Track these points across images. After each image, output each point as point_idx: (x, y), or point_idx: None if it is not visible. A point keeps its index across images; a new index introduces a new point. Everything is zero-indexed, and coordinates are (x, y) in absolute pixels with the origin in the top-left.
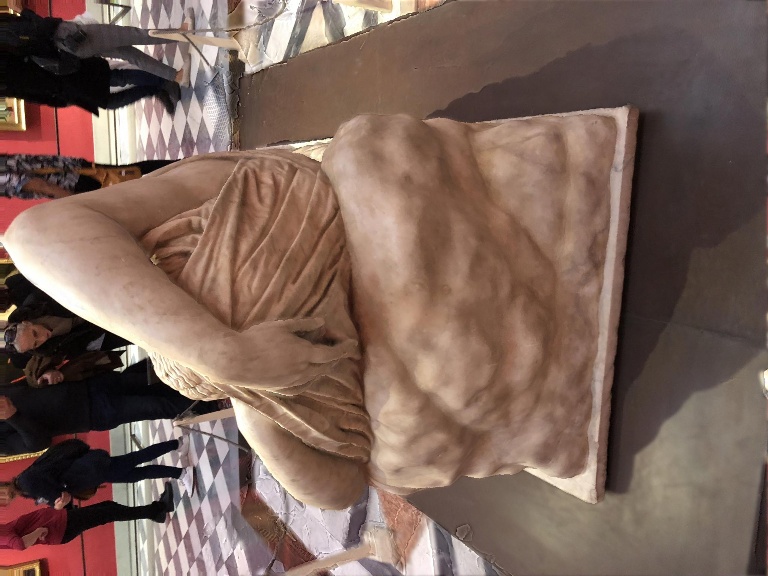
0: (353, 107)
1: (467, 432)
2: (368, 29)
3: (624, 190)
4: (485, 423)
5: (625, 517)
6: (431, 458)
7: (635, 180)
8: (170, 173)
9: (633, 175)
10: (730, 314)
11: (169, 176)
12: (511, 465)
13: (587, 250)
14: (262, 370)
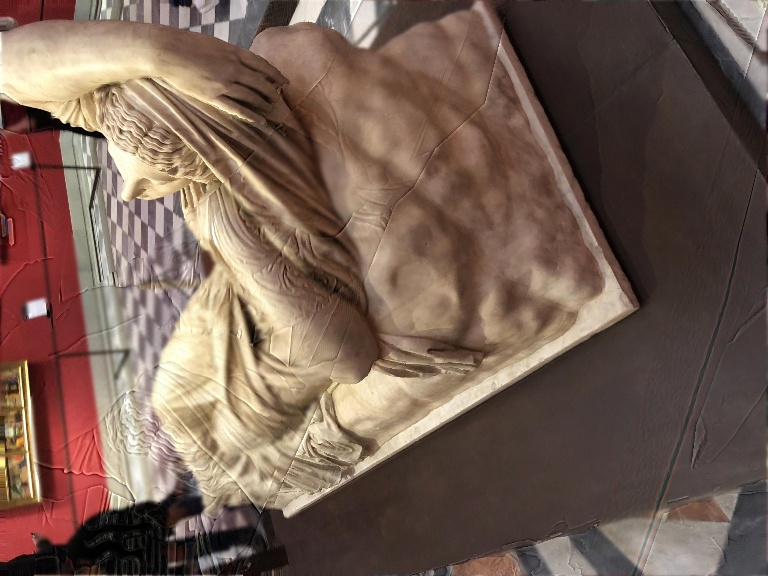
0: None
1: (447, 220)
2: None
3: (506, 48)
4: (462, 212)
5: None
6: (419, 245)
7: (513, 42)
8: None
9: (509, 39)
10: (629, 58)
11: None
12: (527, 302)
13: (496, 87)
14: (193, 44)
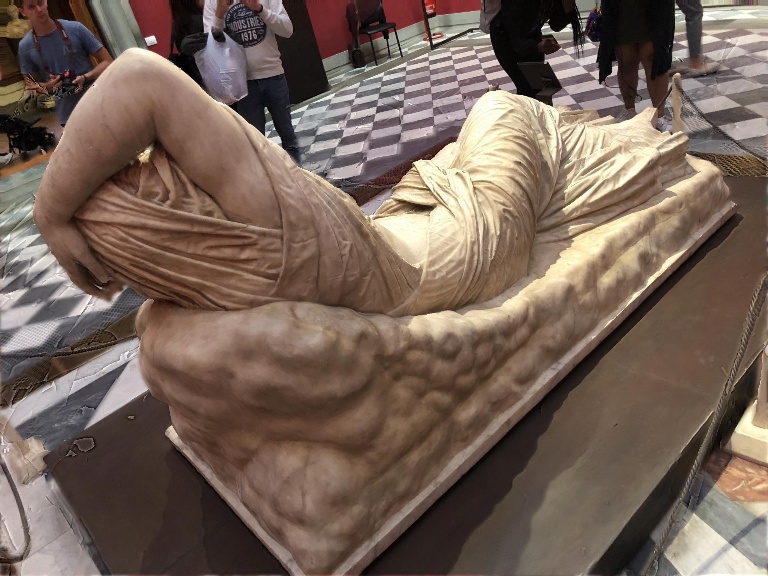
0: (662, 338)
1: None
2: (740, 385)
3: None
4: None
5: (157, 450)
6: None
7: (286, 572)
8: (245, 171)
9: (289, 573)
10: None
11: (236, 171)
12: None
13: (246, 503)
14: None
